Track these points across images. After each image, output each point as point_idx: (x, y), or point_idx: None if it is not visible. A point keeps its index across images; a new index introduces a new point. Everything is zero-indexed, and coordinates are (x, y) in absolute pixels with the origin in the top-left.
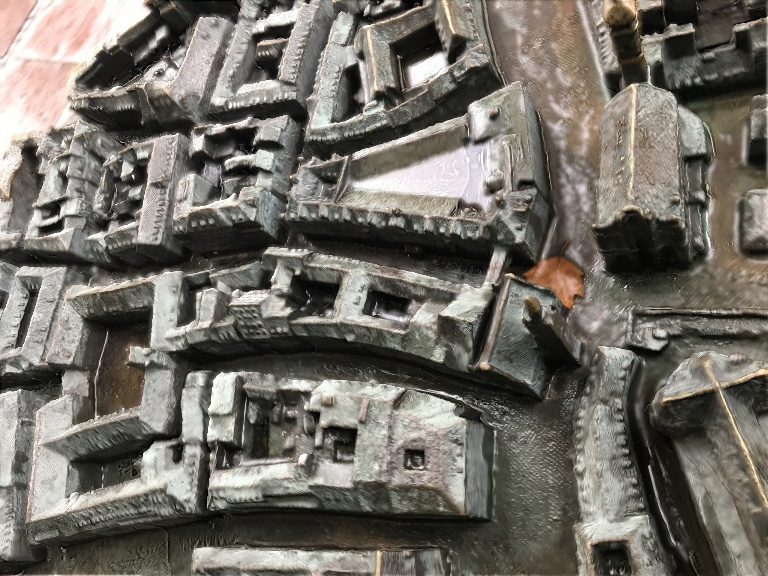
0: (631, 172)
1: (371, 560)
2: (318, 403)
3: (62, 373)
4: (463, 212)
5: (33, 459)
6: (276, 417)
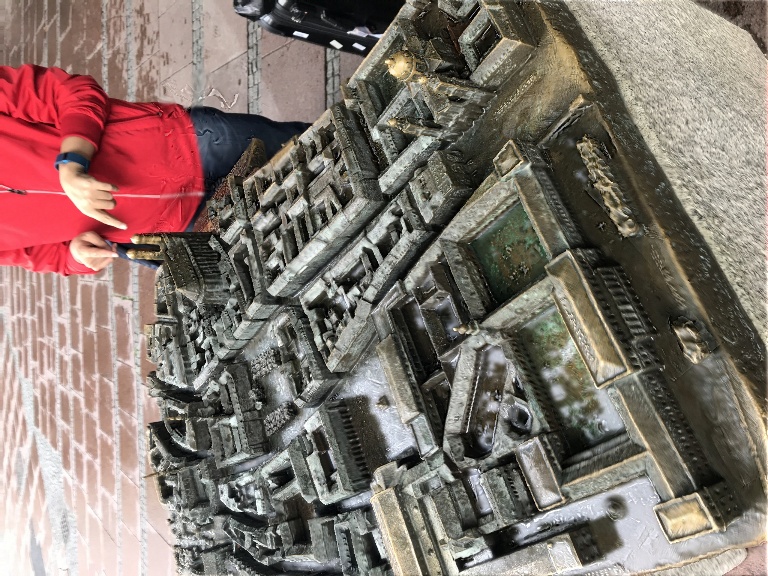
0: (203, 564)
1: (223, 465)
2: (235, 505)
3: (316, 514)
4: (233, 565)
5: (295, 474)
6: (251, 499)
